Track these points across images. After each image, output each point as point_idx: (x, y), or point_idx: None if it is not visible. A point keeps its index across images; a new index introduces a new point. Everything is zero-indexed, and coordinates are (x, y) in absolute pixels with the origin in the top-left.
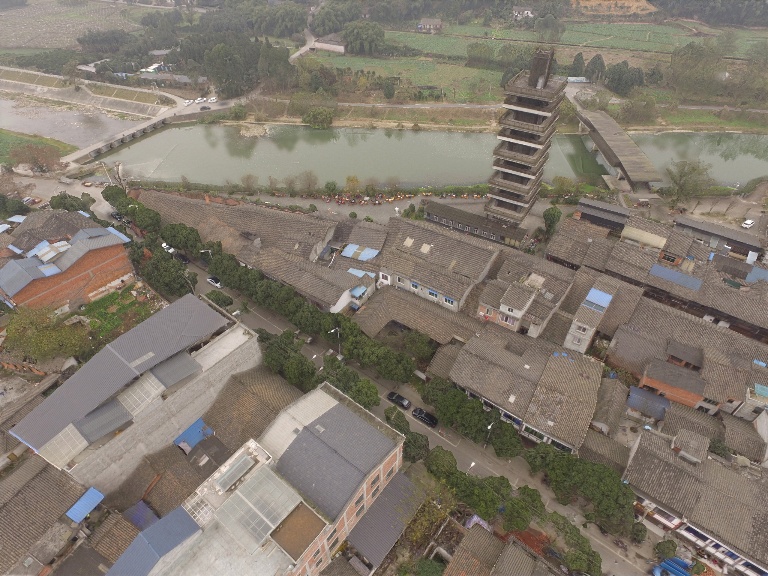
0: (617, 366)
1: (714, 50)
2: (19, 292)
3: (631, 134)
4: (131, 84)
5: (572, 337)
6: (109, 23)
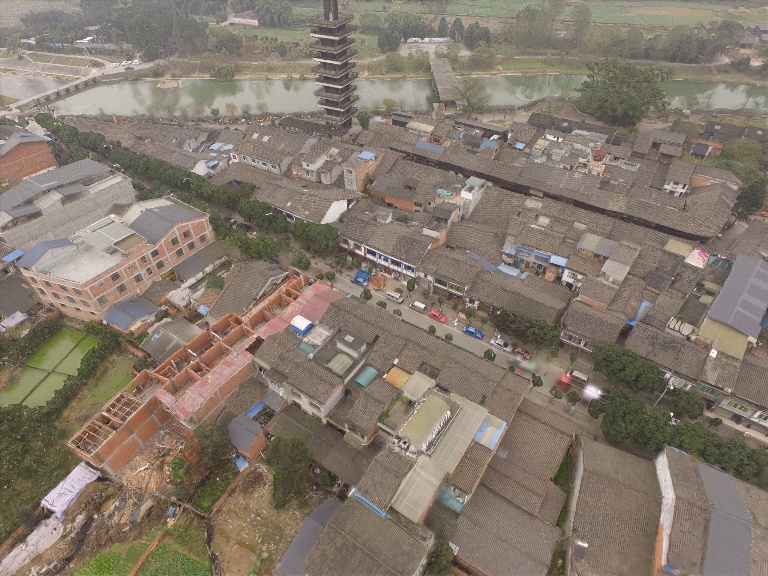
0: (374, 196)
1: (544, 11)
2: None
3: (472, 77)
4: (67, 52)
5: (347, 180)
6: (52, 7)
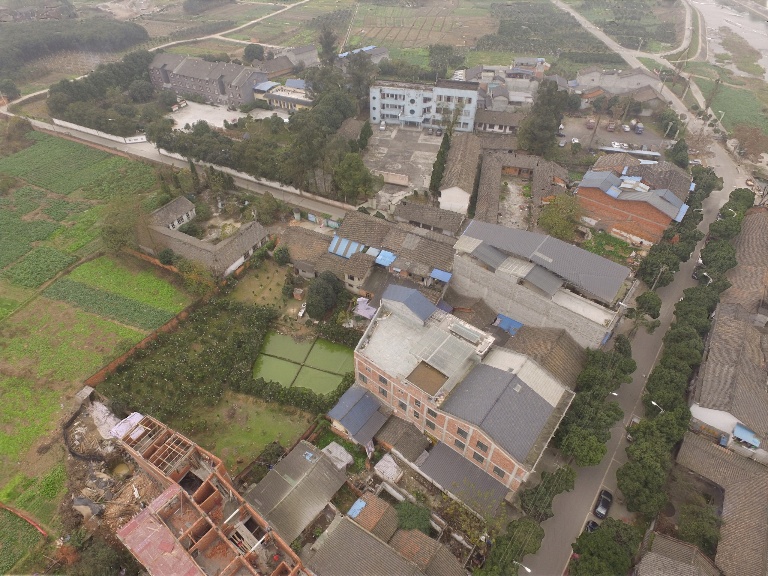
0: None
1: None
2: (585, 188)
3: None
4: None
5: None
6: None
